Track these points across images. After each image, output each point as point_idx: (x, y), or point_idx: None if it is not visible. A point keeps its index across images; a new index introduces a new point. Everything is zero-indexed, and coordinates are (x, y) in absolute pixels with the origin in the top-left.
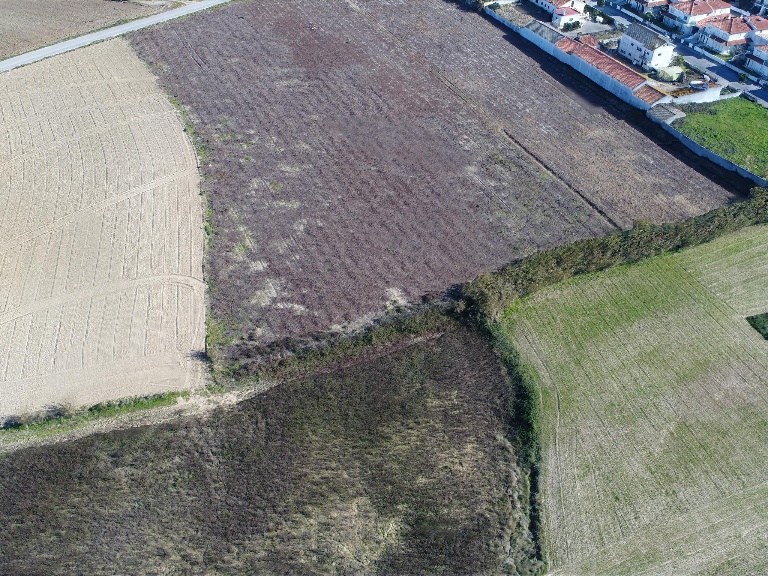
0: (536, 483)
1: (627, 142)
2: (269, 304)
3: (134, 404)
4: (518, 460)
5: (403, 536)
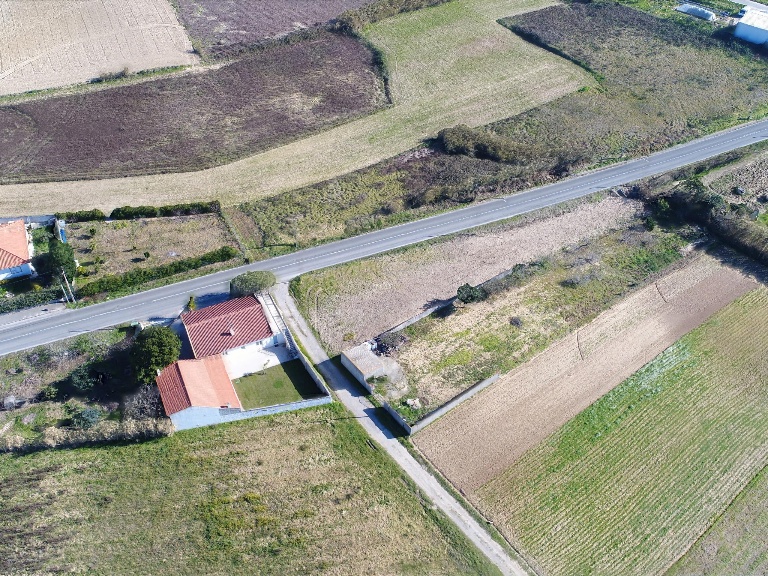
0: (387, 82)
1: None
2: (225, 31)
3: (162, 71)
4: (377, 76)
5: (323, 101)
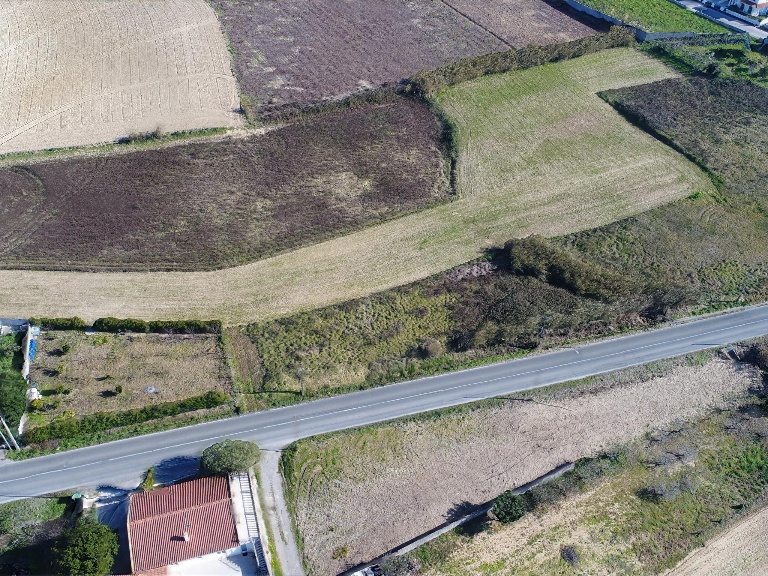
0: (455, 166)
1: (529, 5)
2: (280, 87)
3: (199, 133)
4: (444, 157)
5: (374, 186)
